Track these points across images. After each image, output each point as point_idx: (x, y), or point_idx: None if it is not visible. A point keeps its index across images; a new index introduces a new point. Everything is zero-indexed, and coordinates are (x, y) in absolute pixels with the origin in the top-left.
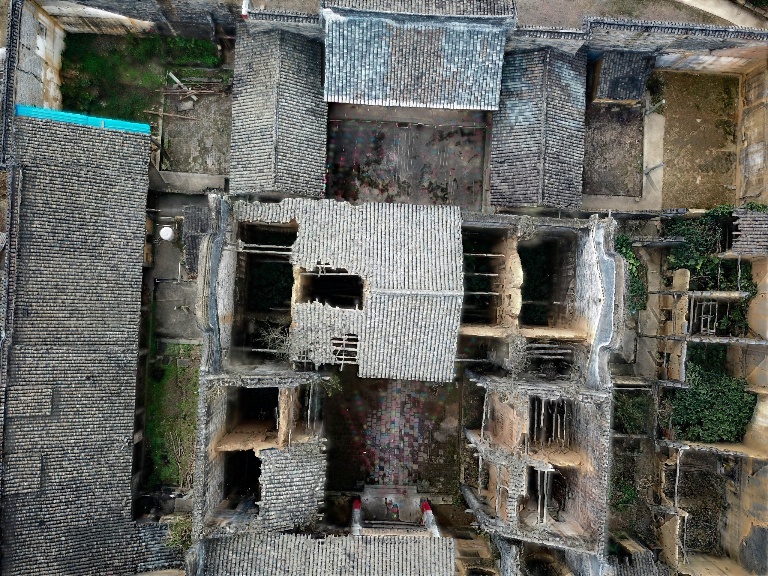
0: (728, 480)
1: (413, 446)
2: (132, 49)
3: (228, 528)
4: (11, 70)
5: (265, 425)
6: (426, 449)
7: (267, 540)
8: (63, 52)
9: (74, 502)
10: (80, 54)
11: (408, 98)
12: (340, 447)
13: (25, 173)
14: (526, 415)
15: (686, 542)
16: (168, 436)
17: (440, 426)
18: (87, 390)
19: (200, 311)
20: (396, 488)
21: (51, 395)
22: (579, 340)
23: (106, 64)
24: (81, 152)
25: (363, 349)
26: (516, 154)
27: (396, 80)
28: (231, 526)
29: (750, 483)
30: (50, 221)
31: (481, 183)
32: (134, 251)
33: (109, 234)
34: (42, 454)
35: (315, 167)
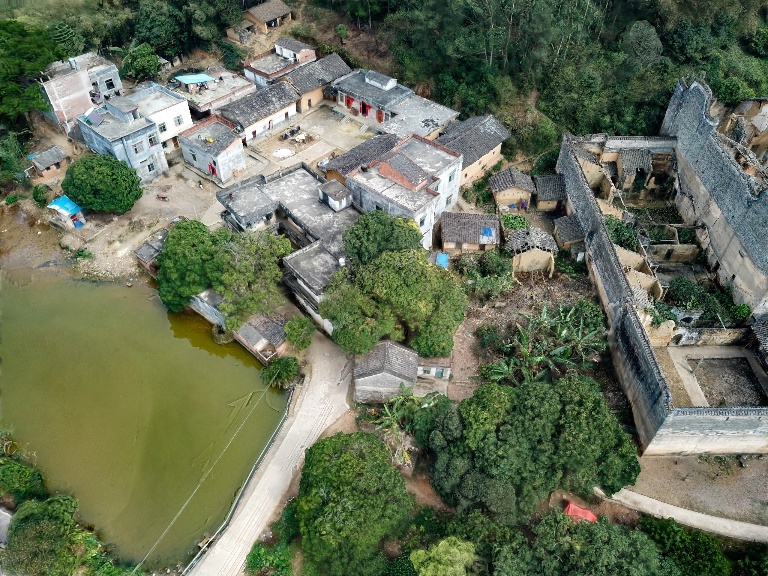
0: None
1: None
2: None
3: None
4: None
5: None
6: None
7: None
8: None
9: None
10: None
11: None
12: None
13: None
14: None
15: None
16: None
17: None
18: None
19: None
20: None
21: None
22: None
23: None
24: None
25: None
26: None
27: None
28: None
29: None
30: None
31: None
32: None
33: None
34: None
35: None
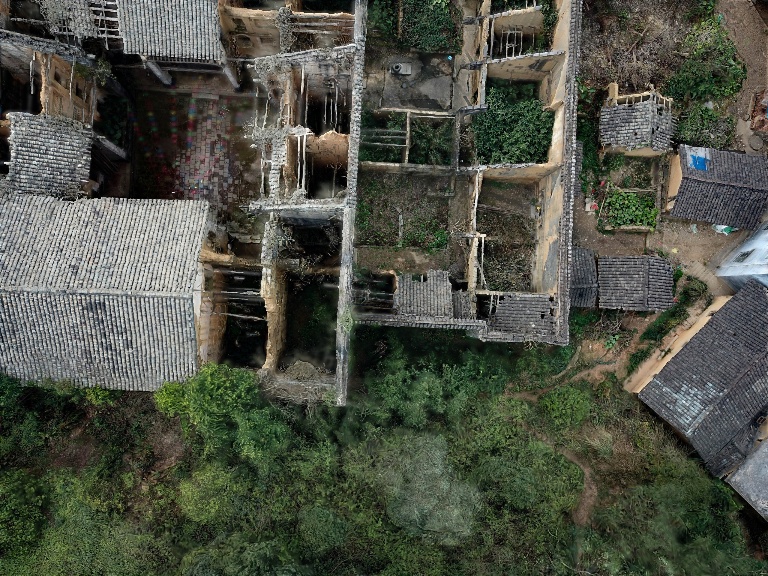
0: (538, 218)
1: (223, 187)
2: None
3: None
4: None
5: None
6: (236, 190)
7: (15, 199)
8: None
9: None
10: None
11: None
12: (148, 187)
13: None
14: (289, 85)
15: (499, 286)
16: None
17: (251, 167)
18: None
19: None
20: None
21: None
22: (351, 21)
23: None
24: None
25: (123, 17)
26: None
27: None
28: None
29: (549, 206)
30: None
31: None
32: None
33: None
34: None
35: None
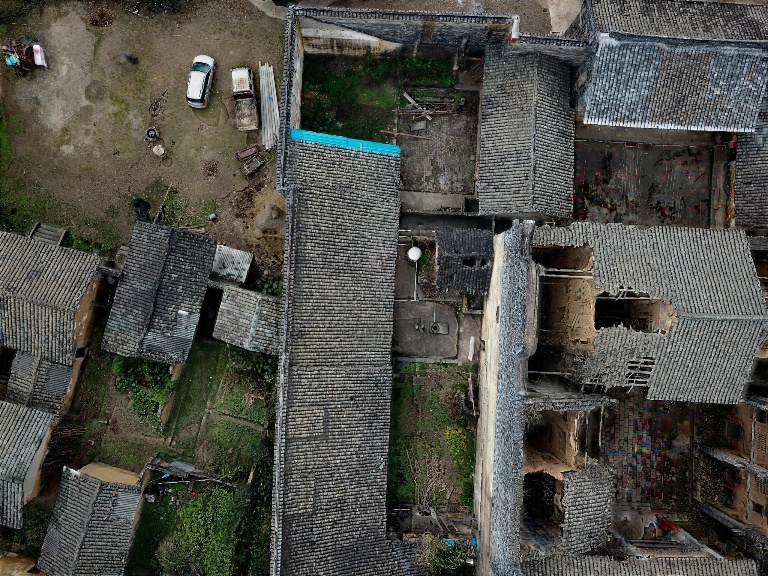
0: None
1: (646, 463)
2: (370, 69)
3: (540, 551)
4: (289, 93)
5: (533, 445)
6: (659, 466)
7: (573, 562)
8: (302, 72)
9: (339, 521)
10: (317, 74)
11: (667, 120)
12: None
13: (299, 195)
14: None
15: None
16: (404, 454)
17: (672, 444)
18: (350, 410)
19: (530, 337)
20: (630, 505)
21: (323, 416)
22: None
23: (344, 84)
24: (343, 174)
25: (657, 372)
26: (764, 175)
27: (658, 103)
28: (542, 549)
29: None
30: (319, 243)
31: (708, 202)
32: (388, 271)
33: (367, 255)
34: (314, 474)
35: (564, 188)
